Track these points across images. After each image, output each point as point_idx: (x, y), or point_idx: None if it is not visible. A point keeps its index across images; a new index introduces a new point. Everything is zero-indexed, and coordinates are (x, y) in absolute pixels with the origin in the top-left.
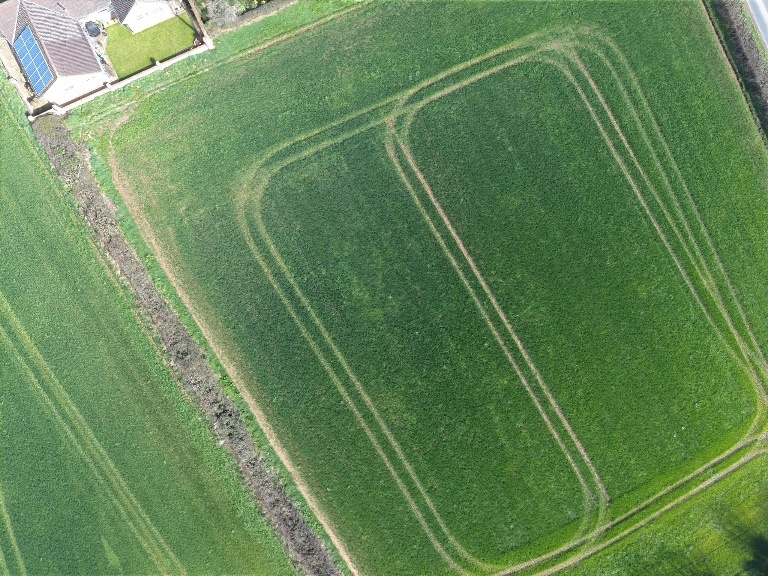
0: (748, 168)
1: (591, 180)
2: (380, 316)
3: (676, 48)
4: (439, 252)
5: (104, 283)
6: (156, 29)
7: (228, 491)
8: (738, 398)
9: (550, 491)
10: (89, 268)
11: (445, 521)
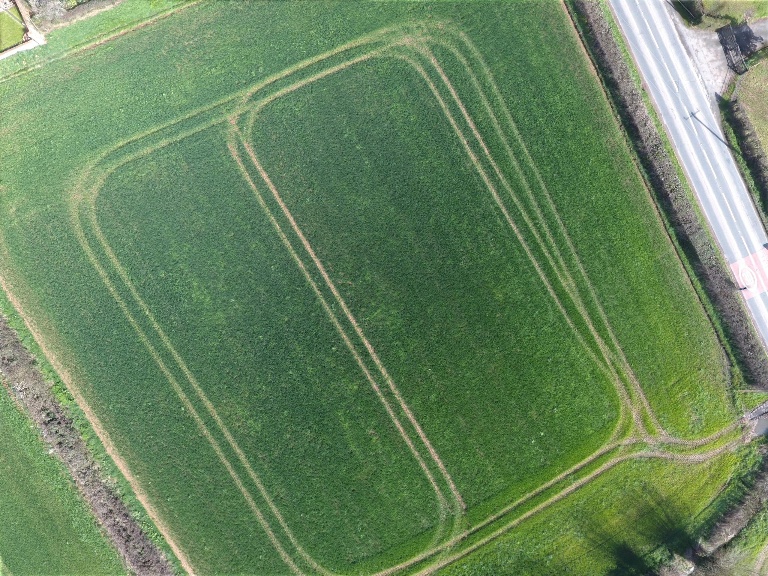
0: (608, 166)
1: (444, 179)
2: (222, 320)
3: (532, 43)
4: (284, 253)
5: None
6: None
7: (62, 501)
8: (599, 402)
9: (402, 499)
10: None
11: (292, 531)
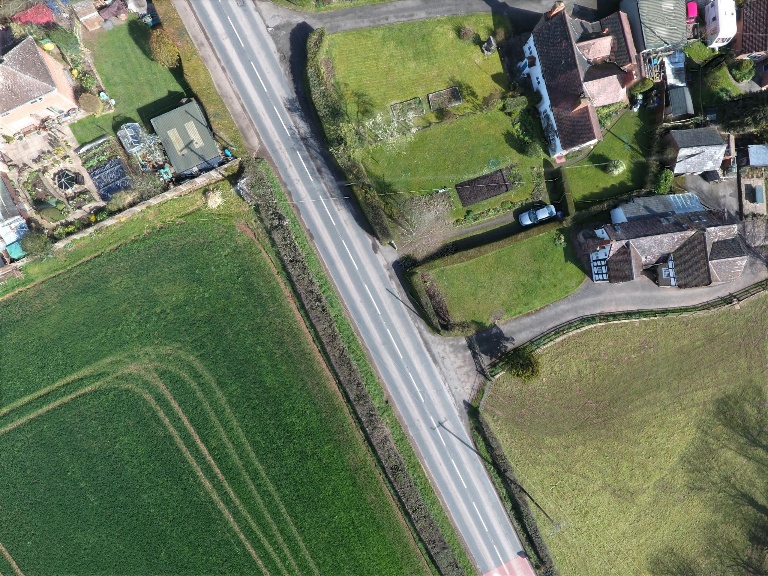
0: (351, 484)
1: (175, 510)
2: None
3: (267, 363)
4: None
5: None
6: None
7: None
8: None
9: None
10: None
11: None
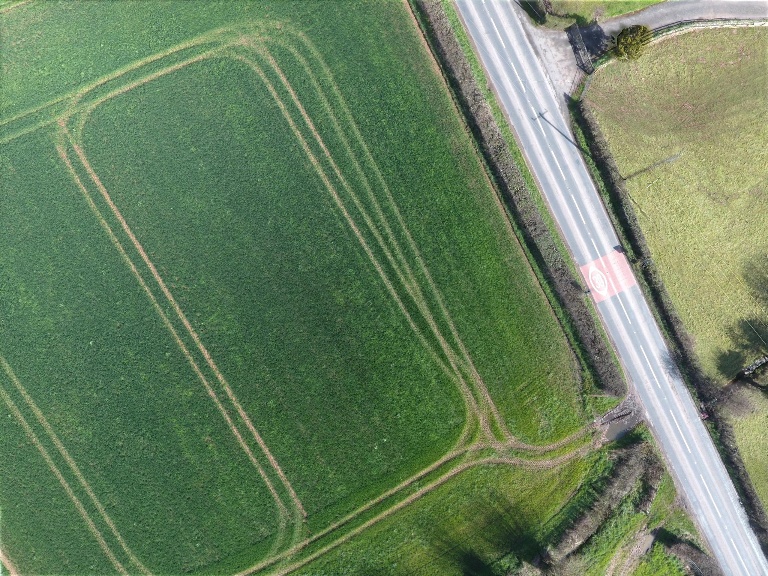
0: (453, 168)
1: (282, 181)
2: (51, 325)
3: (374, 43)
4: (115, 257)
5: None
6: None
7: None
8: (444, 408)
9: (240, 507)
10: None
11: (125, 540)
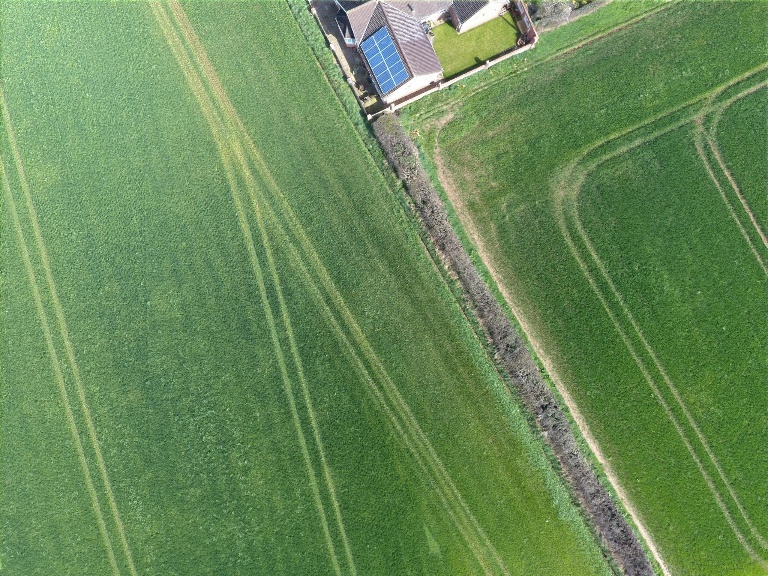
0: None
1: None
2: (689, 311)
3: None
4: (746, 248)
5: (432, 278)
6: (481, 29)
7: (544, 481)
8: None
9: None
10: (418, 263)
11: (748, 513)
